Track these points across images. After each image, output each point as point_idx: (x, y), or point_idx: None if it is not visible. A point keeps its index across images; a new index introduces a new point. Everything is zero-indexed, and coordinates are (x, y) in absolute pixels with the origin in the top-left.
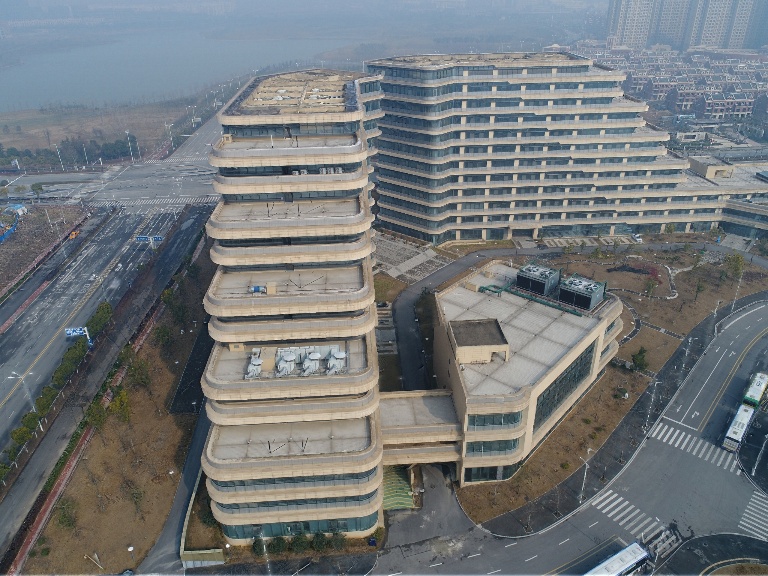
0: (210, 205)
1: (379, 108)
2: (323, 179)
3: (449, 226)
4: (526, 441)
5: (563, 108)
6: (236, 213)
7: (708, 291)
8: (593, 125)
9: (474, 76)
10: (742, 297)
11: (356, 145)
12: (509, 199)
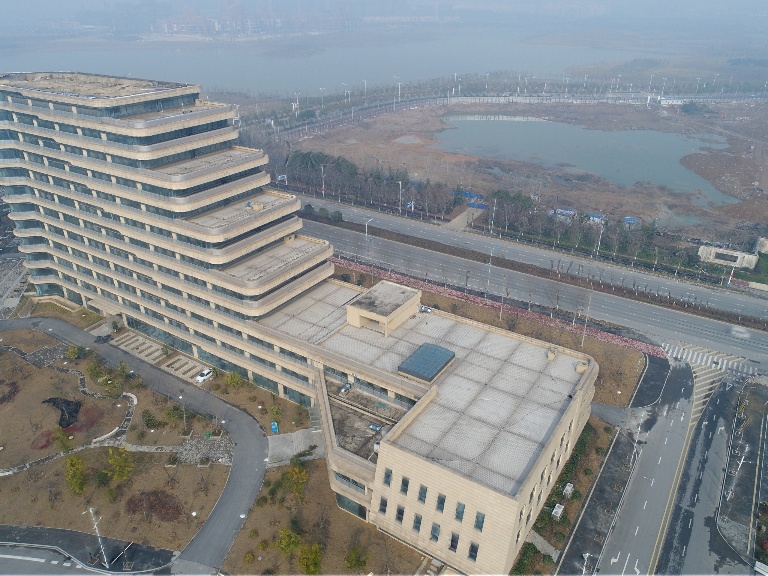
0: None
1: None
2: None
3: (54, 278)
4: None
5: (96, 162)
6: None
7: (48, 492)
8: (126, 194)
9: (16, 104)
10: (60, 528)
11: None
12: (86, 266)
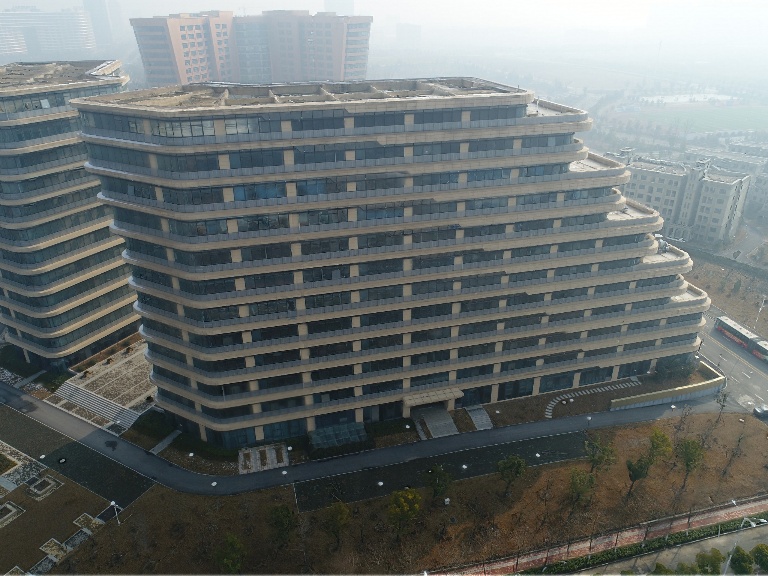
0: None
1: None
2: None
3: None
4: None
5: None
6: None
7: None
8: None
9: None
10: None
11: None
12: None
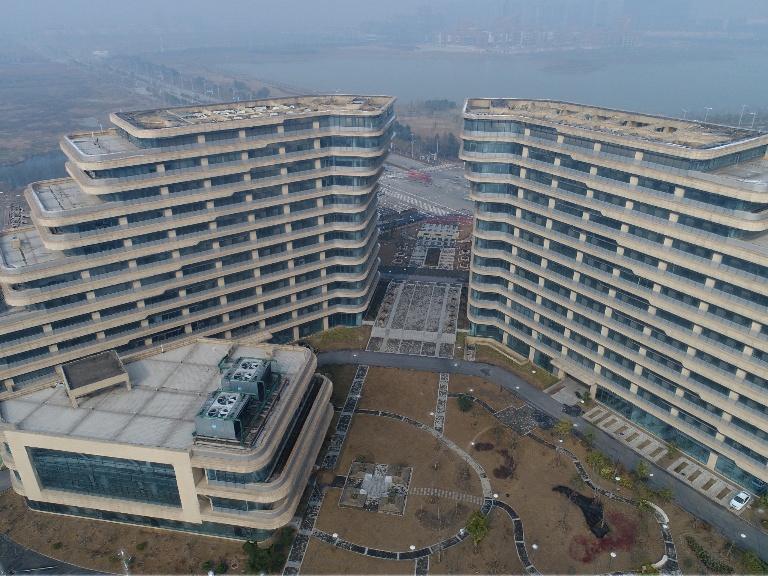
0: (428, 215)
1: (370, 147)
2: (83, 178)
3: (496, 321)
4: (27, 483)
5: (646, 219)
6: (66, 186)
7: None
8: (689, 263)
9: (536, 138)
10: None
11: (89, 155)
12: (561, 322)
